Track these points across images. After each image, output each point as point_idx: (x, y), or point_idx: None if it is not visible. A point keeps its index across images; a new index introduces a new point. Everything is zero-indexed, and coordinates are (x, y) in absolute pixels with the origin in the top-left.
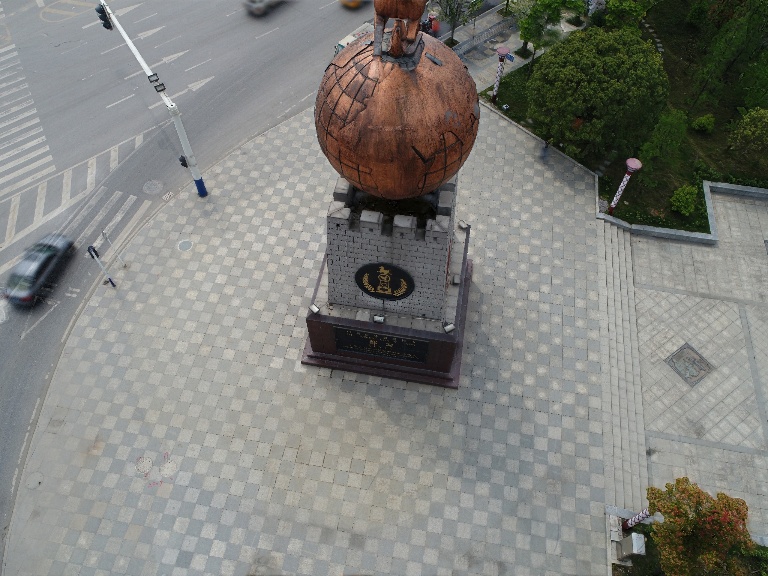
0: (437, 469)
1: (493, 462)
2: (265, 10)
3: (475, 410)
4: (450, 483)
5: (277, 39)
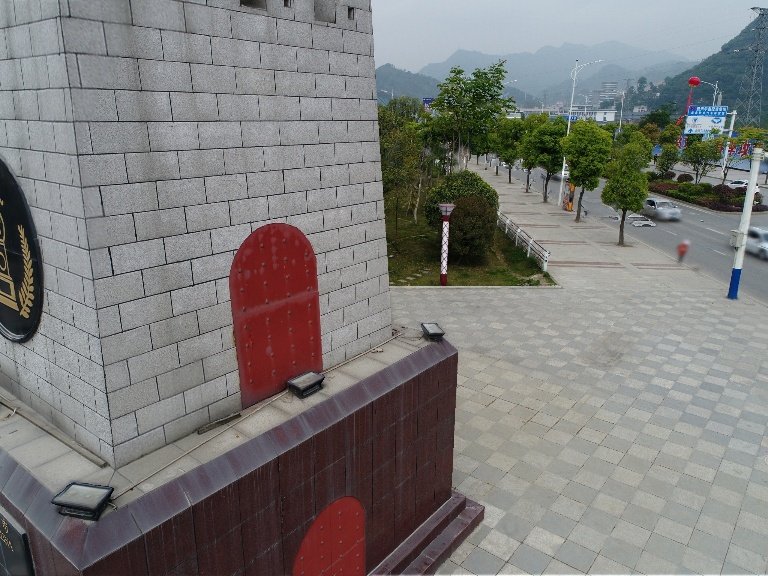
0: None
1: None
2: None
3: None
4: None
5: None
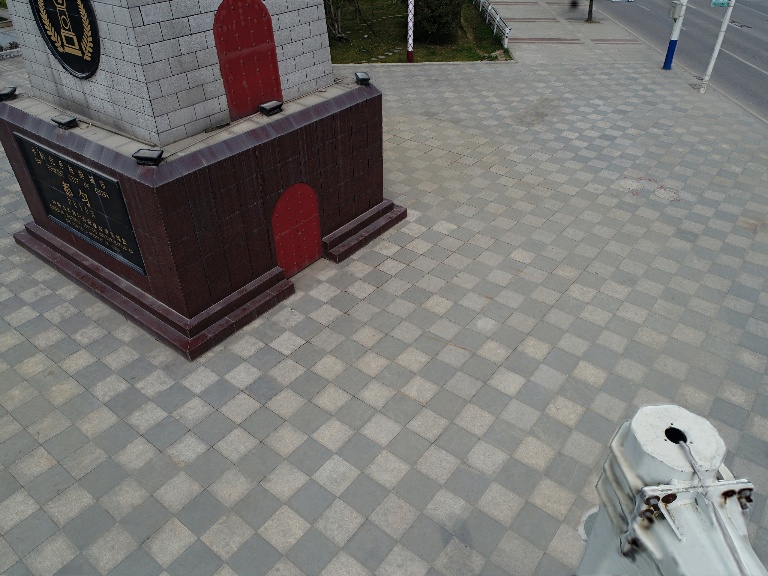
0: None
1: None
2: None
3: None
4: None
5: None
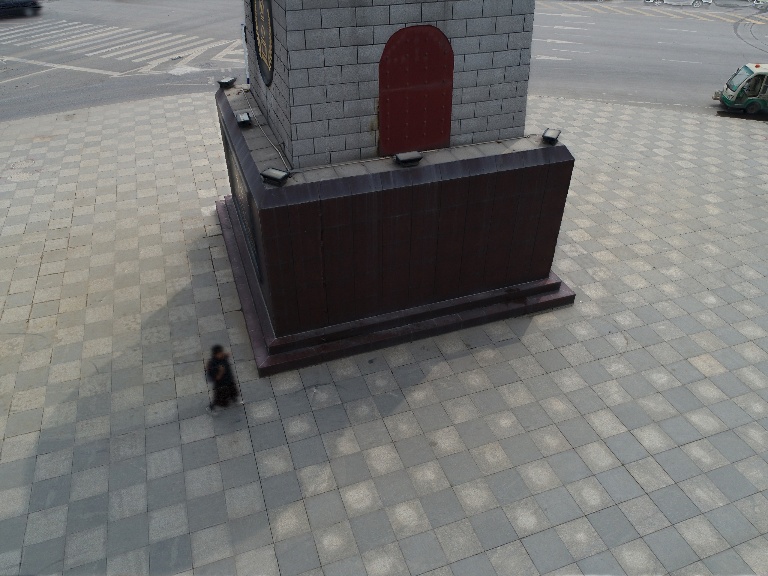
0: (54, 408)
1: (89, 500)
2: (708, 51)
3: (222, 421)
4: (20, 439)
5: (685, 67)
